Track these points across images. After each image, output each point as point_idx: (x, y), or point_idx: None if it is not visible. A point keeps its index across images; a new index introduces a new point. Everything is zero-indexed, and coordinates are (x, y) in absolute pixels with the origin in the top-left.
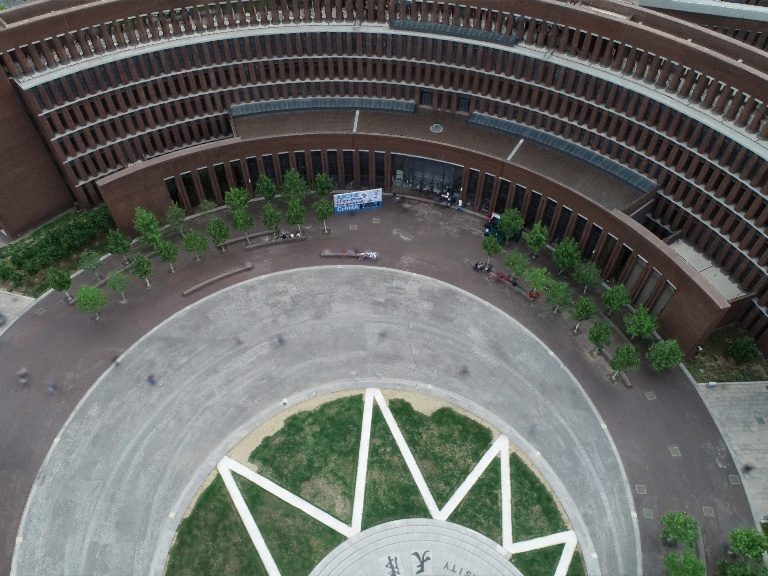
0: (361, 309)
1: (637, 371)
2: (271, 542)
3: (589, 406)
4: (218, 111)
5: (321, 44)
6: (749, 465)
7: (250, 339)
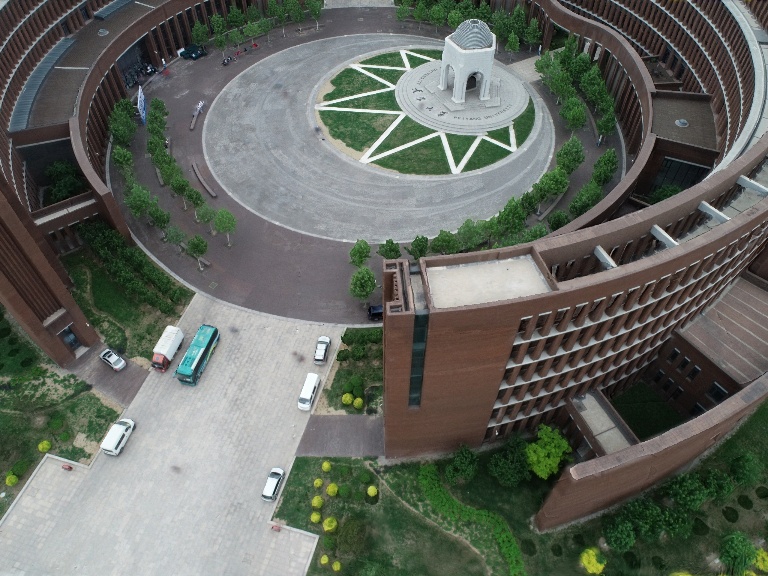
0: (250, 111)
1: (314, 22)
2: (410, 139)
3: (334, 38)
4: (8, 143)
5: (0, 28)
6: (368, 4)
7: (268, 159)
